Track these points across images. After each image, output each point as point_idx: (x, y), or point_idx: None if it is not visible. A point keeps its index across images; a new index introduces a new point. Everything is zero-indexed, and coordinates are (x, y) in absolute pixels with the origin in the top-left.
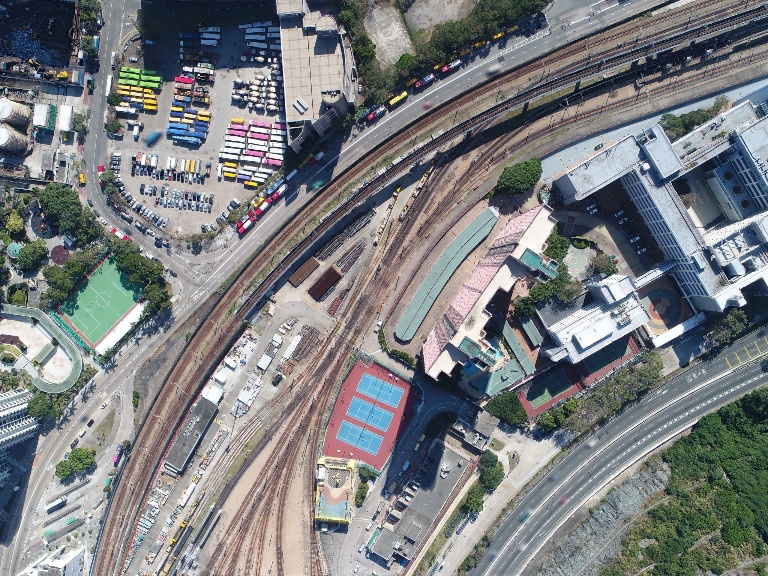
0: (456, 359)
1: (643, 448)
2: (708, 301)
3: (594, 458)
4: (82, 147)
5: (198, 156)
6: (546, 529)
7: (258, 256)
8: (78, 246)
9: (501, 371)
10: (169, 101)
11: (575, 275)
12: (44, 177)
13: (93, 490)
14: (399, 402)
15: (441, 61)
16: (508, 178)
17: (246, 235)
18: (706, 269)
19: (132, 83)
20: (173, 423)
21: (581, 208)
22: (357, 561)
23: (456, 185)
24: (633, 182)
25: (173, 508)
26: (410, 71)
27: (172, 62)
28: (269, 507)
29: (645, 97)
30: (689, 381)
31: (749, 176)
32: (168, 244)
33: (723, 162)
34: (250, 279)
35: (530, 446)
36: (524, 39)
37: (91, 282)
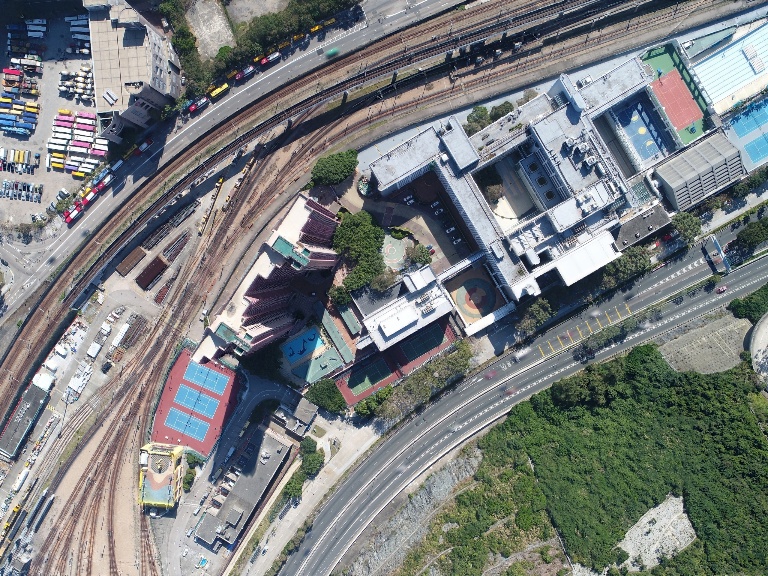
0: (218, 344)
1: (460, 435)
2: (510, 290)
3: (412, 445)
4: None
5: (28, 147)
6: (366, 514)
7: (87, 245)
8: None
9: (320, 359)
10: None
11: (393, 265)
12: None
13: None
14: (225, 389)
15: (258, 53)
16: (320, 169)
17: (75, 225)
18: (505, 259)
19: None
20: (5, 409)
21: (399, 199)
22: (186, 545)
23: (278, 176)
24: (439, 173)
25: (8, 493)
26: (227, 63)
27: (1, 54)
28: (100, 492)
29: (460, 89)
30: (503, 369)
31: (549, 167)
32: None
33: (528, 154)
34: (79, 268)
35: (350, 433)
36: (342, 32)
37: None
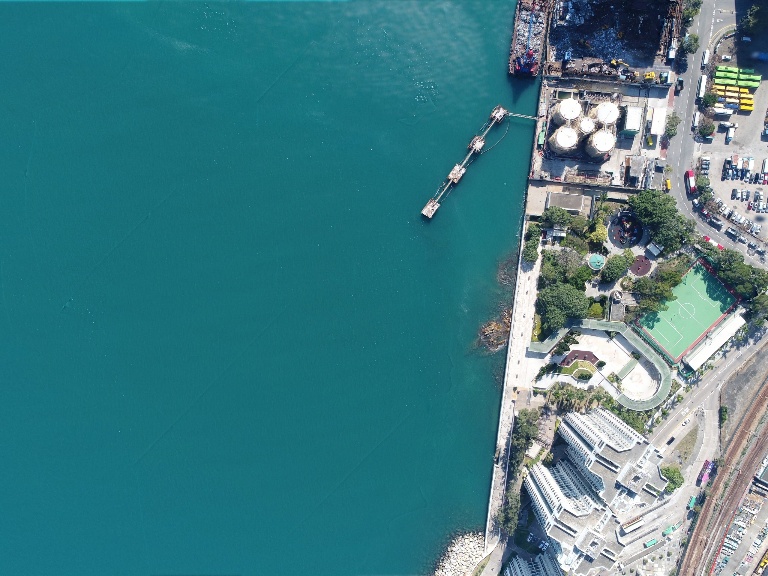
0: None
1: None
2: None
3: None
4: (665, 151)
5: None
6: None
7: None
8: (661, 256)
9: None
10: (764, 101)
11: None
12: (623, 184)
13: (672, 511)
14: None
15: None
16: None
17: None
18: None
19: (730, 83)
20: None
21: None
22: None
23: None
24: None
25: (761, 528)
26: None
27: None
28: None
29: None
30: None
31: None
32: (764, 251)
33: None
34: None
35: None
36: None
37: (674, 293)
